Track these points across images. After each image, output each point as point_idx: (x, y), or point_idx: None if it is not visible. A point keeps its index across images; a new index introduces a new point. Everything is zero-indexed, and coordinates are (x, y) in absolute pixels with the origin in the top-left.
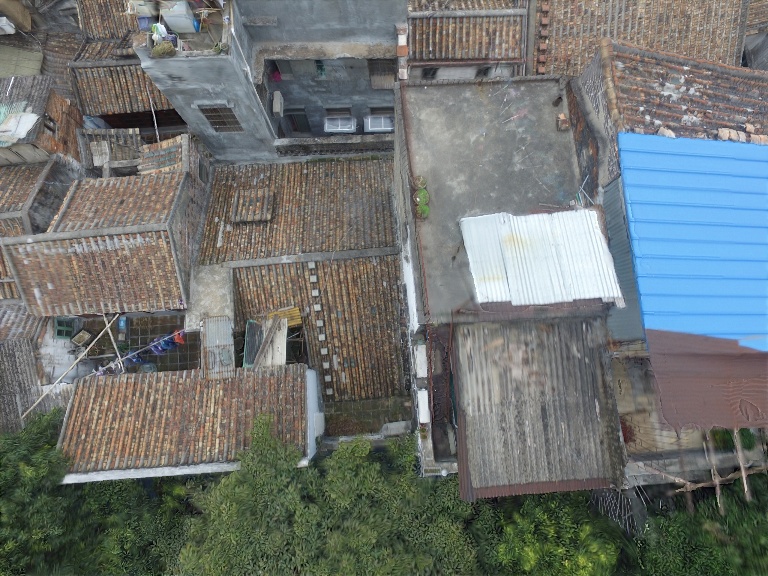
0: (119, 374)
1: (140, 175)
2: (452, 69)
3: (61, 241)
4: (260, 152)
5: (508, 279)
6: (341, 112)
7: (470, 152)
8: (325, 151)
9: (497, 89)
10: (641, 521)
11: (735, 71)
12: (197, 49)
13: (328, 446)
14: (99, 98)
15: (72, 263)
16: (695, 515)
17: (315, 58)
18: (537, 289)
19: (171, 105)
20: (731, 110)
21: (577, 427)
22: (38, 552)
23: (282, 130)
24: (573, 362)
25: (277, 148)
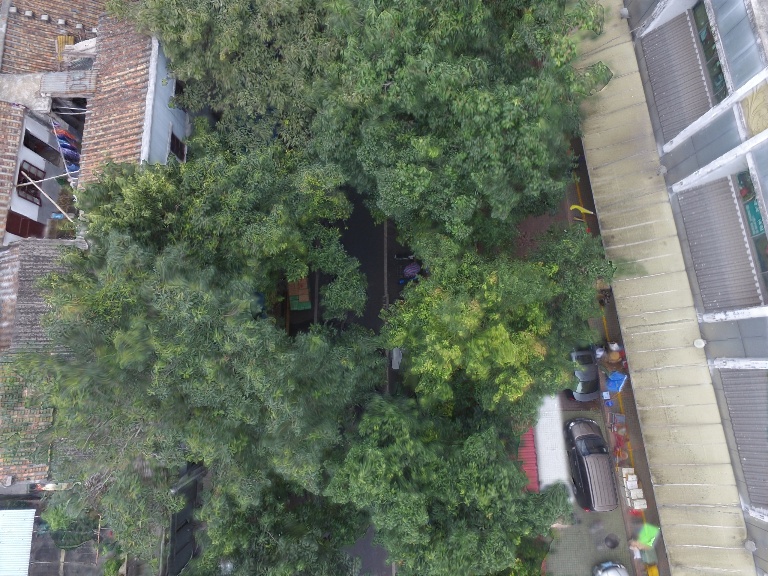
0: None
1: None
2: None
3: None
4: None
5: None
6: None
7: None
8: None
9: None
10: None
11: None
12: None
13: None
14: None
15: None
16: None
17: None
18: None
19: None
20: None
21: None
22: None
23: None
24: None
25: None
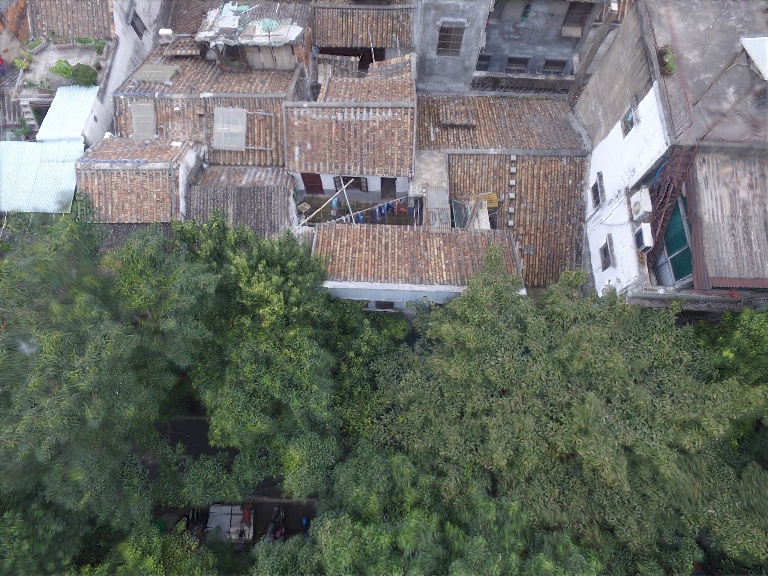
0: None
1: None
2: None
3: (328, 109)
4: (457, 83)
5: None
6: (518, 64)
7: (701, 37)
8: (510, 88)
9: None
10: None
11: None
12: None
13: None
14: (328, 33)
15: (332, 128)
16: None
17: None
18: None
19: (384, 44)
20: None
21: None
22: None
23: None
24: None
25: (473, 80)
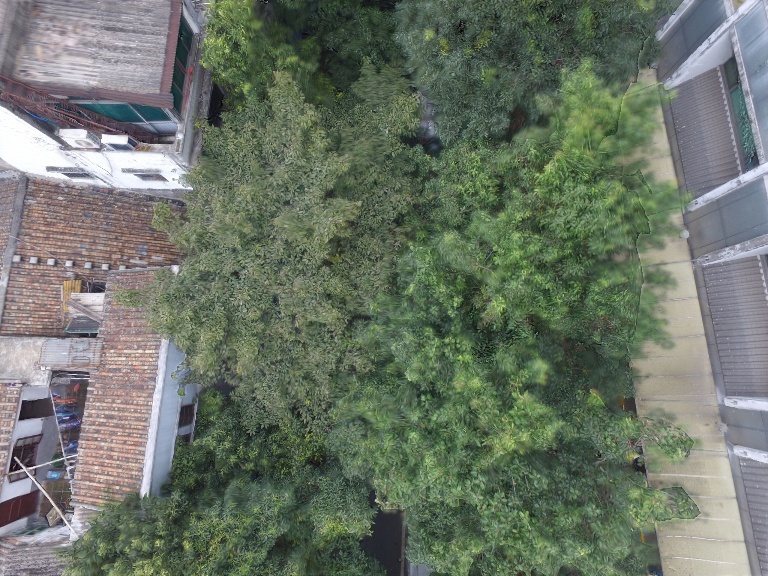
0: None
1: None
2: None
3: None
4: None
5: None
6: None
7: None
8: None
9: None
10: None
11: None
12: None
13: None
14: None
15: None
16: None
17: None
18: None
19: None
20: None
21: (127, 7)
22: None
23: None
24: None
25: None
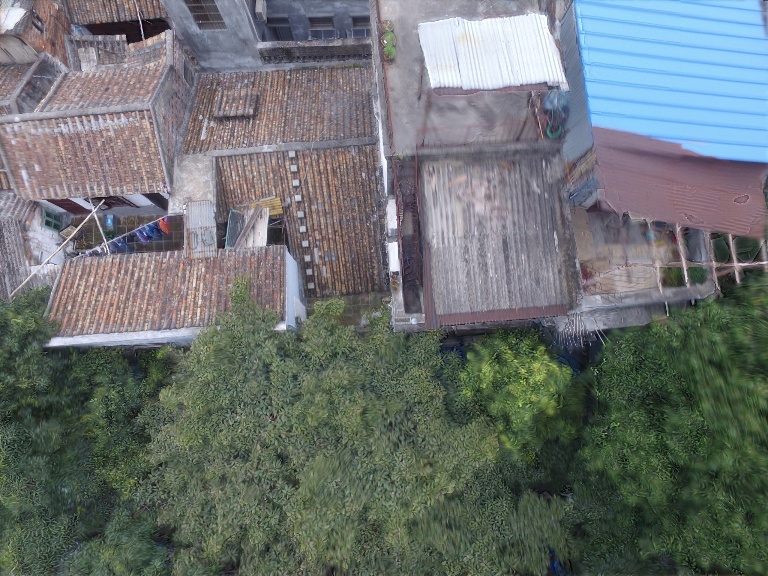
0: (105, 256)
1: None
2: None
3: (47, 121)
4: (244, 57)
5: (459, 64)
6: (324, 24)
7: (437, 3)
8: (308, 58)
9: None
10: (599, 357)
11: None
12: None
13: None
14: (87, 6)
15: (58, 144)
16: (647, 338)
17: None
18: (486, 74)
19: (157, 14)
20: None
21: (536, 258)
22: (25, 406)
23: None
24: (533, 197)
25: (260, 52)
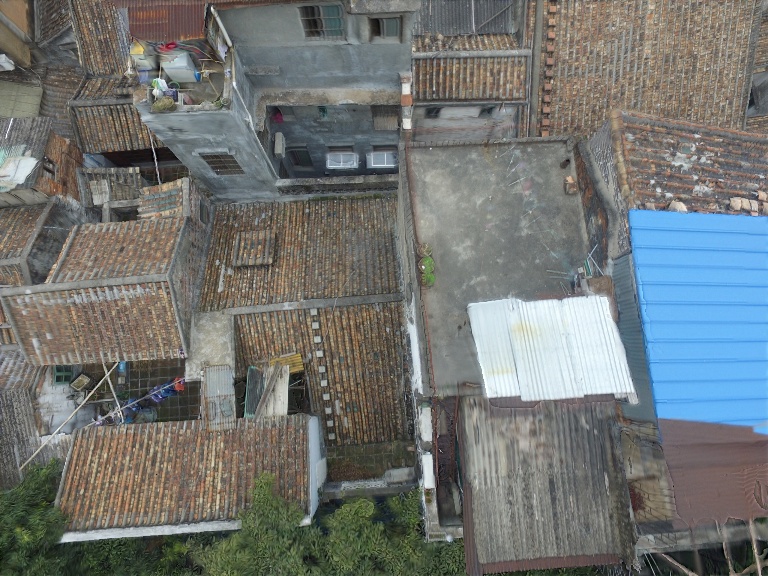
0: (118, 424)
1: (140, 218)
2: (456, 108)
3: (60, 292)
4: (261, 191)
5: (518, 374)
6: (343, 149)
7: (476, 216)
8: (327, 190)
9: (503, 150)
10: None
11: (747, 137)
12: (198, 99)
13: (330, 495)
14: (99, 136)
15: (71, 313)
16: None
17: (317, 104)
18: (547, 384)
19: None
20: (743, 177)
21: (586, 501)
22: None
23: (284, 167)
24: (582, 434)
25: (279, 188)
